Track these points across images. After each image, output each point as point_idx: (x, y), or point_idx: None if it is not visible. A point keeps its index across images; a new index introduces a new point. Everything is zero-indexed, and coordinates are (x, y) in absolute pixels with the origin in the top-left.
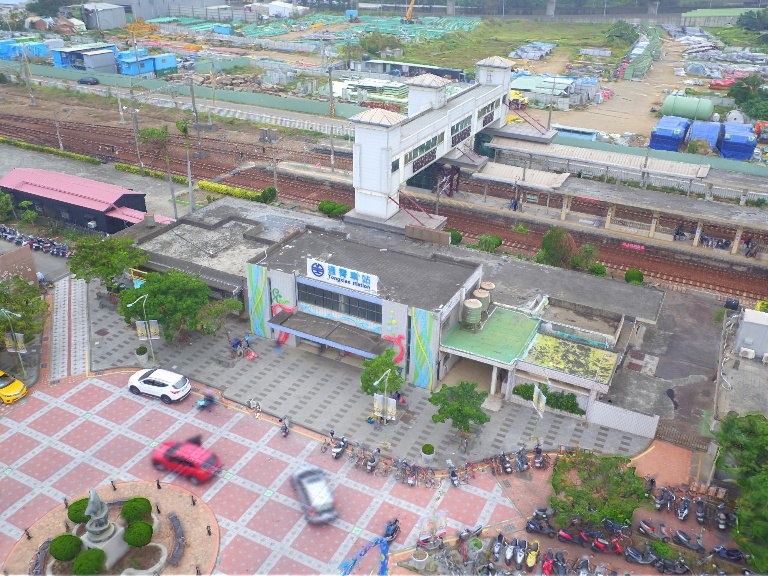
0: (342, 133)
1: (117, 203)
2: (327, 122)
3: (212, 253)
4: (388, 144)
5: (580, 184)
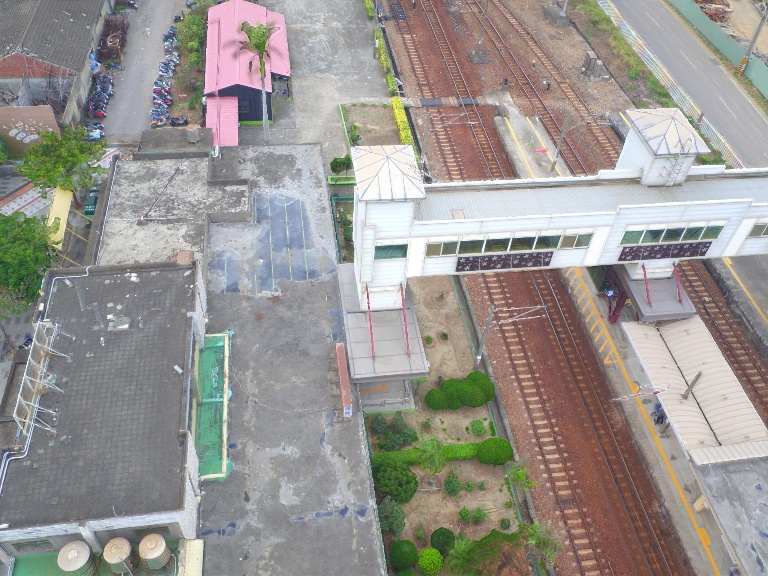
0: (689, 111)
1: (227, 91)
2: (713, 80)
3: (142, 219)
4: (367, 220)
5: (764, 489)
